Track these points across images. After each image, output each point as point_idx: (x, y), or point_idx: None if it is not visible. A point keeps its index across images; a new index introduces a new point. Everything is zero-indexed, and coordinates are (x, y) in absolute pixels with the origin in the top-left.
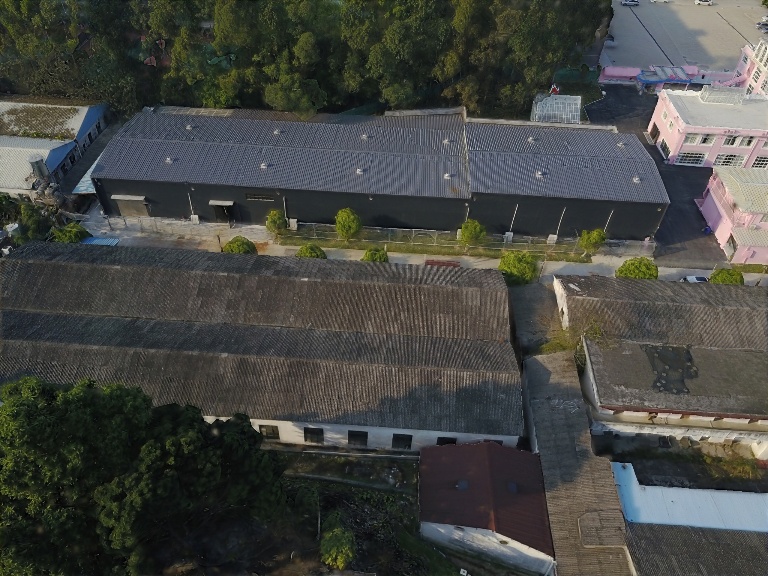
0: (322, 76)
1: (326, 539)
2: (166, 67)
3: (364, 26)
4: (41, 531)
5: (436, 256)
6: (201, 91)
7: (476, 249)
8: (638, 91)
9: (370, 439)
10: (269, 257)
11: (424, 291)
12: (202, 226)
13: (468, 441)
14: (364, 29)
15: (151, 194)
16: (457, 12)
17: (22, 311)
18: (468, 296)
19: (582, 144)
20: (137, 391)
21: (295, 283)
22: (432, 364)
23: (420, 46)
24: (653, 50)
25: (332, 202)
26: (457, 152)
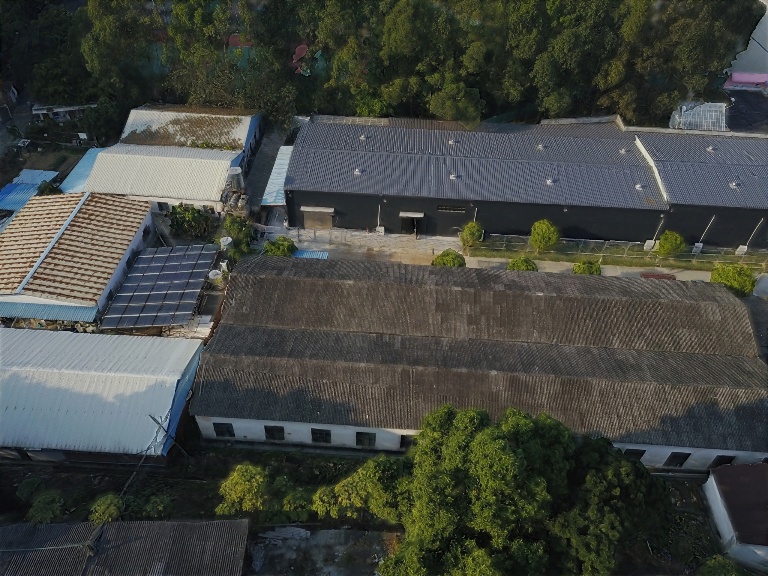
0: (470, 84)
1: (710, 566)
2: (321, 76)
3: (531, 35)
4: (516, 565)
5: (629, 267)
6: (355, 100)
7: (666, 260)
8: (767, 97)
9: (644, 457)
10: (487, 270)
11: (662, 306)
12: (387, 237)
13: (749, 459)
14: (532, 38)
15: (340, 206)
16: (628, 21)
17: (264, 327)
18: (707, 311)
19: (762, 154)
20: (529, 417)
21: (531, 298)
22: (702, 381)
23: (584, 55)
24: (763, 55)
25: (524, 213)
26: (639, 162)
